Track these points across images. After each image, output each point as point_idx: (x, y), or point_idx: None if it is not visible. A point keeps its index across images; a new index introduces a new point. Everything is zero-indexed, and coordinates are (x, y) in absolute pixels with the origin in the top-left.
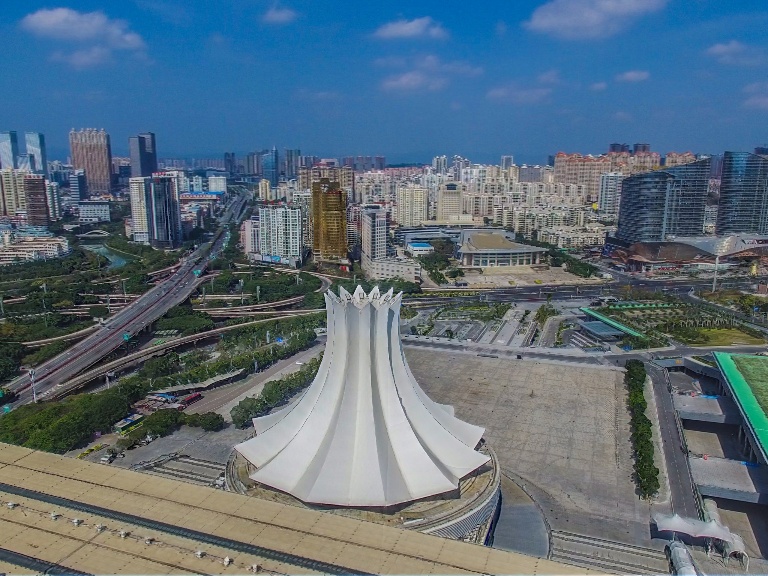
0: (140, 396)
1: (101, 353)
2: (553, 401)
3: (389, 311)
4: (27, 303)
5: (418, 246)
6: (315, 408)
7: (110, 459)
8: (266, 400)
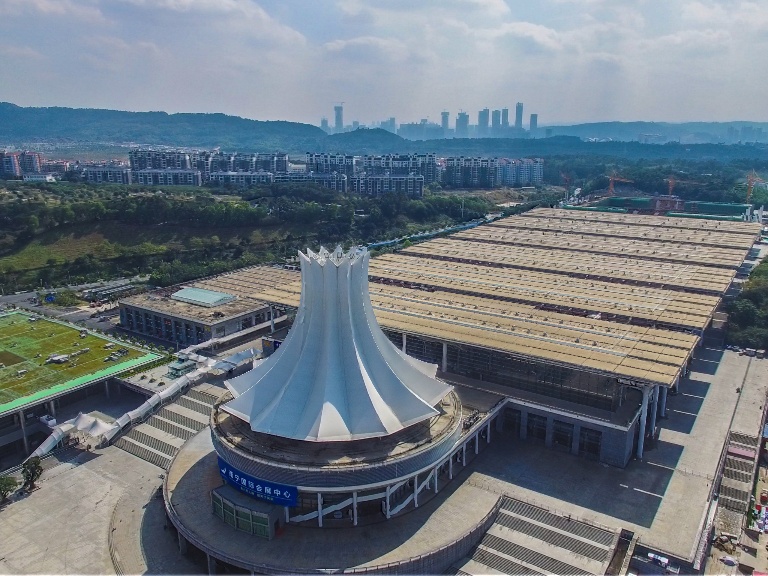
0: None
1: None
2: None
3: None
4: None
5: None
6: None
7: None
8: None
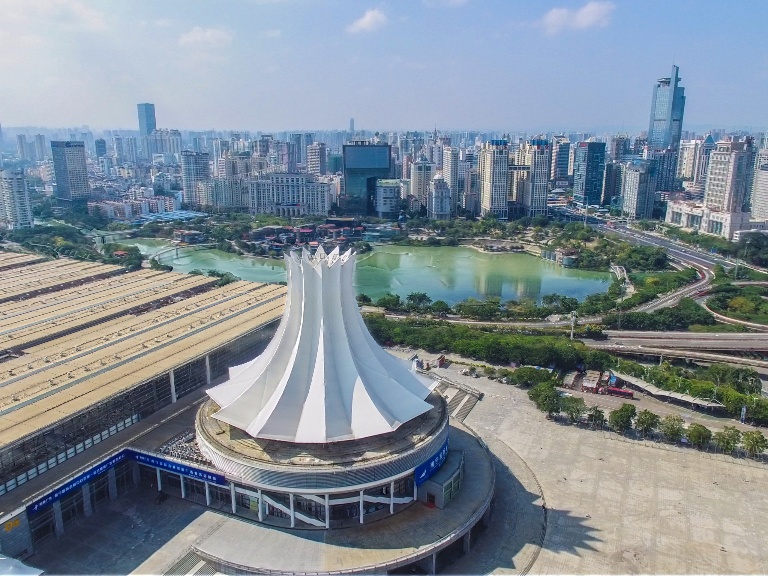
0: (603, 368)
1: (734, 346)
2: None
3: None
4: None
5: None
6: None
7: (467, 373)
8: (610, 418)
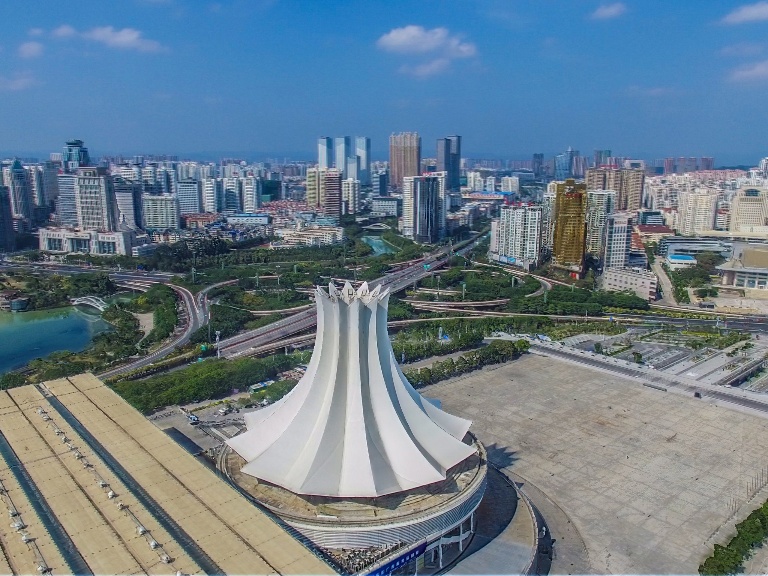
0: (291, 367)
1: (300, 327)
2: (691, 451)
3: (365, 309)
4: (276, 280)
5: (677, 258)
6: (294, 392)
7: (226, 412)
8: None
